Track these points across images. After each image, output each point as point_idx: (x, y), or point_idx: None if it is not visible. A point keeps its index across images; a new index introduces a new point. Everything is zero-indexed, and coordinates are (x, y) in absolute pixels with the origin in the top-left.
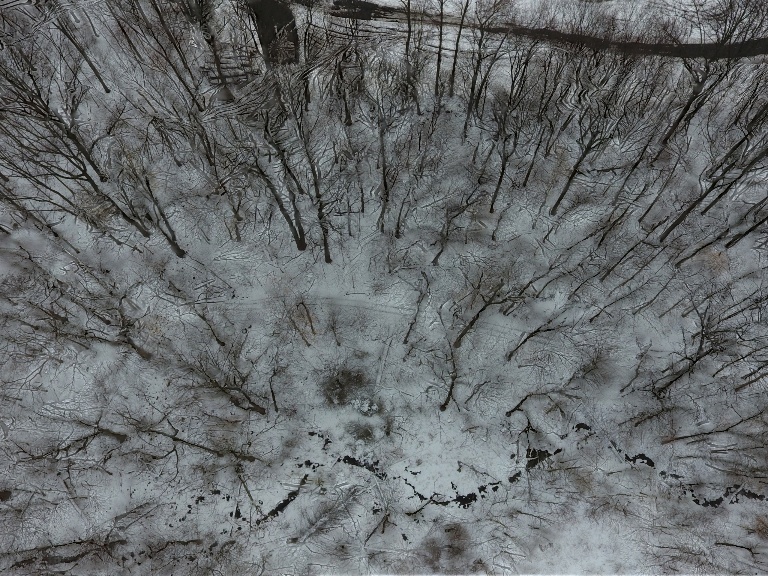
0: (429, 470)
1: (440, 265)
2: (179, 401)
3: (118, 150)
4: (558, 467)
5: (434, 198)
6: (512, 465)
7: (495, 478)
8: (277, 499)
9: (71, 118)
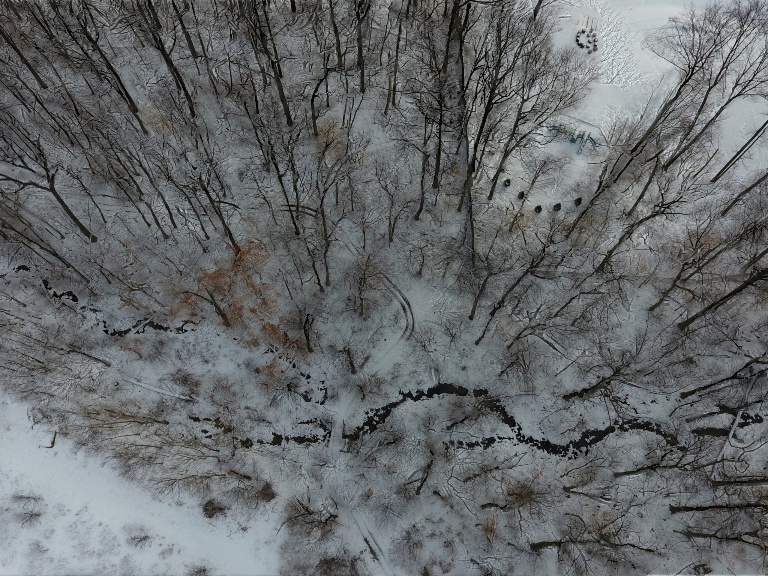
0: None
1: None
2: None
3: None
4: None
5: None
6: None
7: None
8: None
9: None
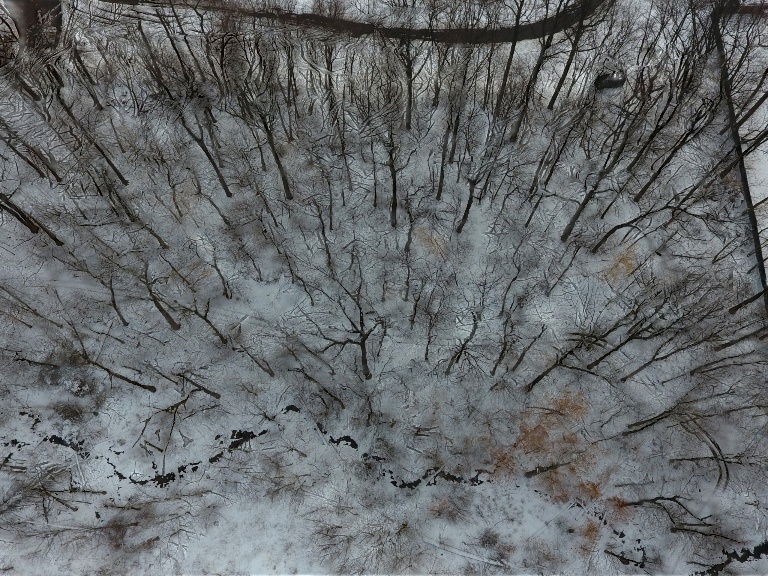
0: (132, 450)
1: (170, 248)
2: None
3: None
4: (256, 448)
5: (173, 182)
6: (215, 446)
7: (196, 458)
8: None
9: None
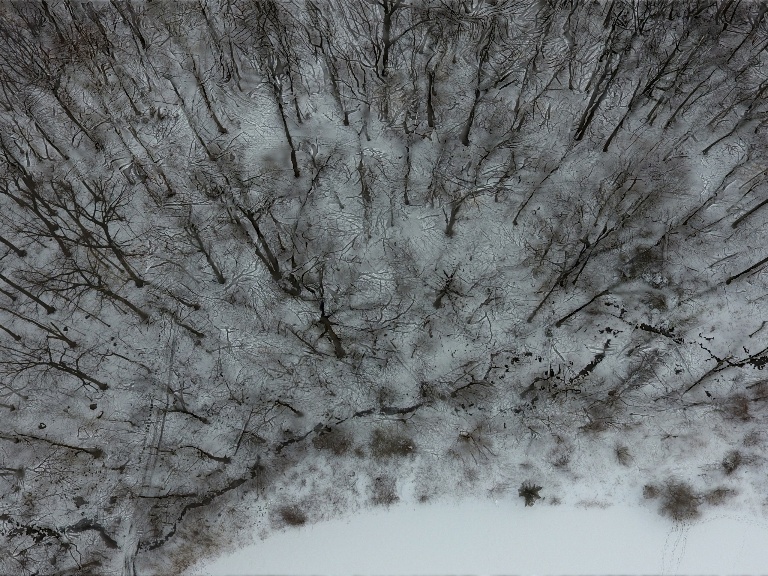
0: (722, 336)
1: (709, 155)
2: (484, 273)
3: (436, 34)
4: None
5: None
6: None
7: None
8: (586, 360)
9: (396, 2)
